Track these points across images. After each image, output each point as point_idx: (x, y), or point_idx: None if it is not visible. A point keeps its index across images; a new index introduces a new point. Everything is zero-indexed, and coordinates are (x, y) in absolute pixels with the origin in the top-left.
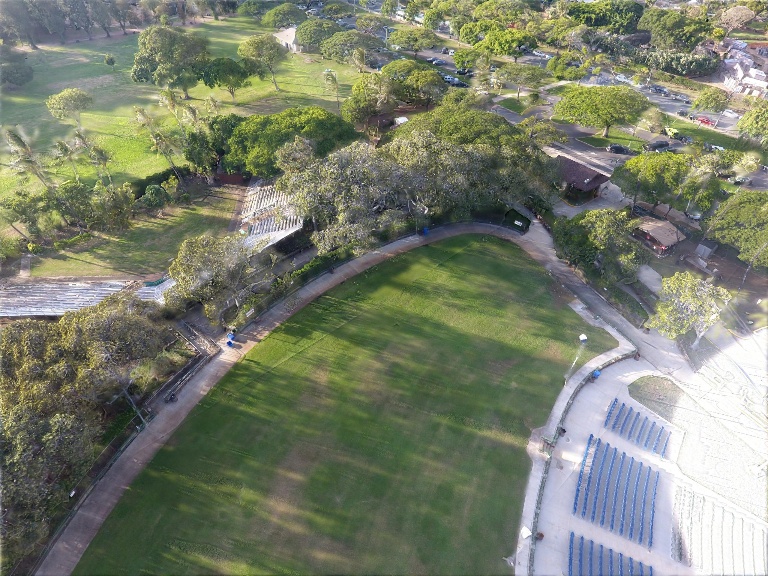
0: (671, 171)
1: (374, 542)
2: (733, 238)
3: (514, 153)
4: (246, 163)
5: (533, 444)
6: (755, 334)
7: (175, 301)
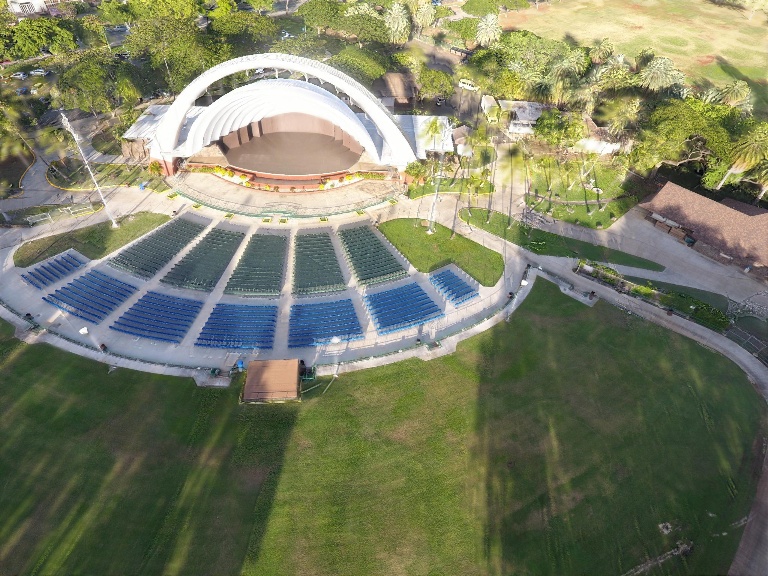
0: None
1: (51, 474)
2: None
3: None
4: None
5: (27, 338)
6: (22, 188)
7: None
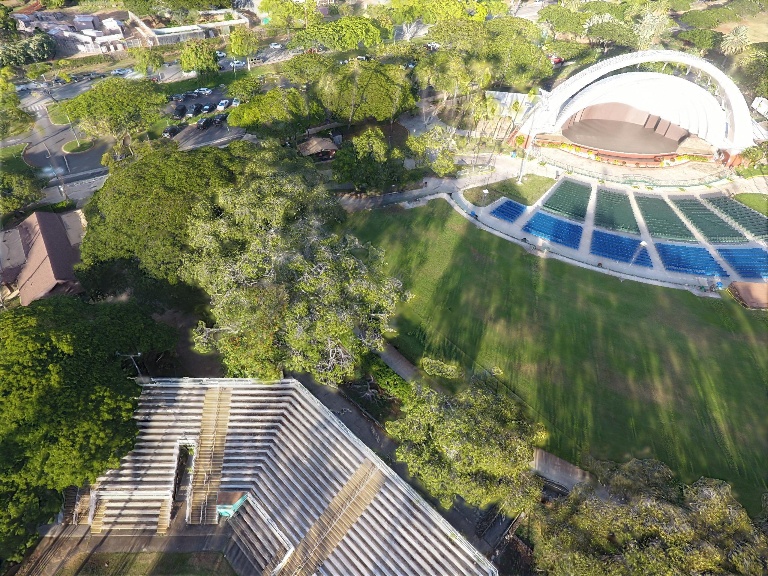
0: (289, 104)
1: (650, 339)
2: (363, 114)
3: (270, 153)
4: (74, 481)
5: (539, 254)
6: None
7: (537, 480)
